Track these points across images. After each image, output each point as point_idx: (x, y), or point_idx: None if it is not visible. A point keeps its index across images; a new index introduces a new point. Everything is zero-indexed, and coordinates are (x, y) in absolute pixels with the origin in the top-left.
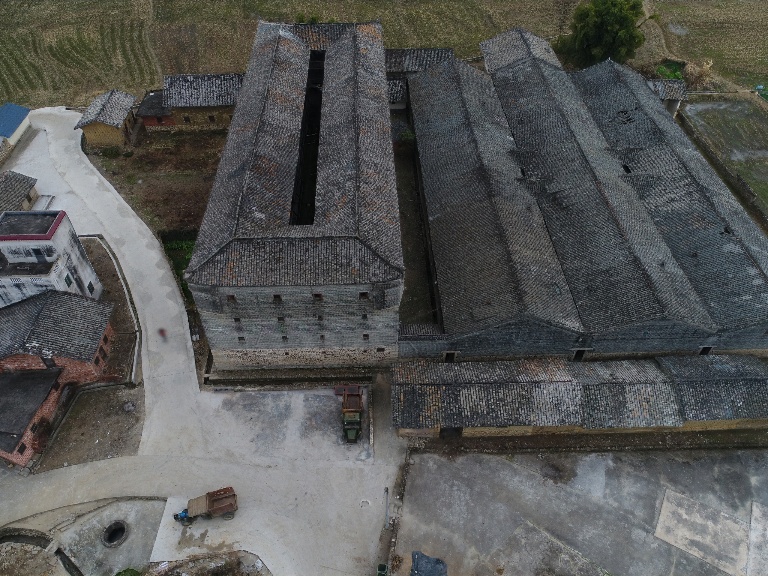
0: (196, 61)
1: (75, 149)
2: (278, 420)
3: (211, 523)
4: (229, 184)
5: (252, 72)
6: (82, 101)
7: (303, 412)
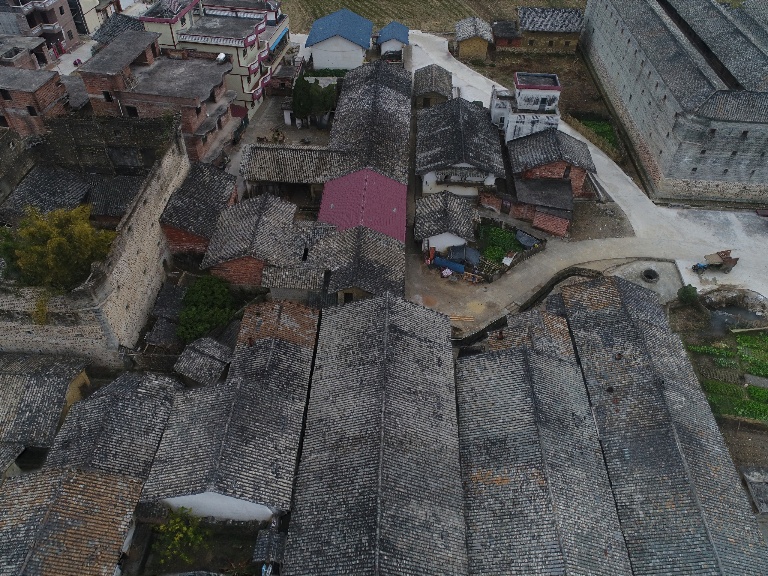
0: (496, 6)
1: (451, 59)
2: (725, 226)
3: (715, 274)
4: (674, 64)
5: (620, 1)
6: (427, 28)
7: (740, 223)
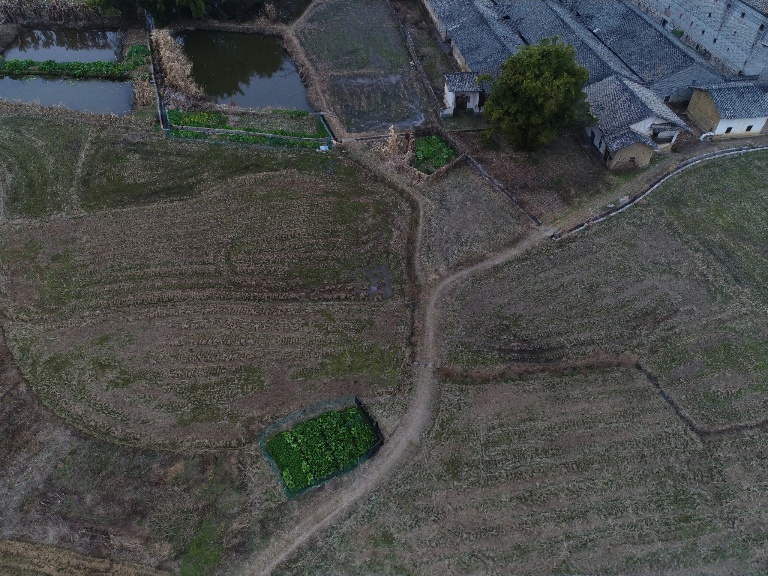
0: None
1: None
2: None
3: None
4: None
5: None
6: None
7: None
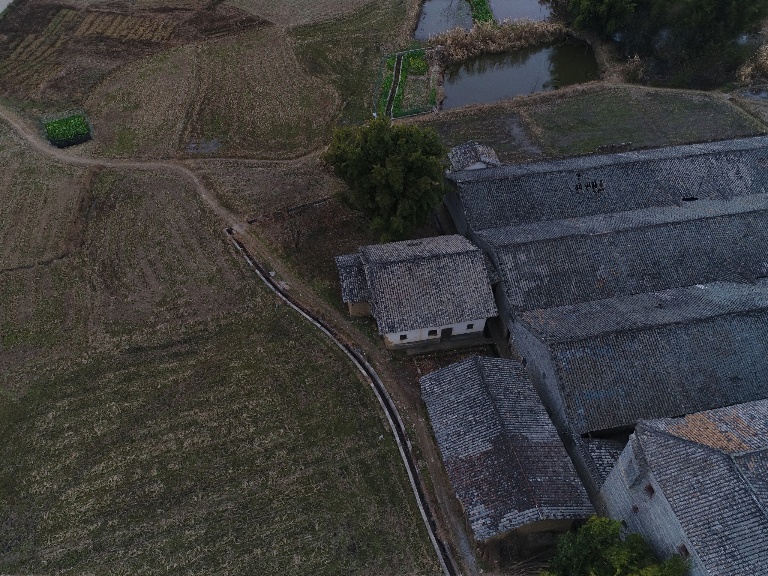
0: None
1: None
2: None
3: None
4: None
5: None
6: None
7: None
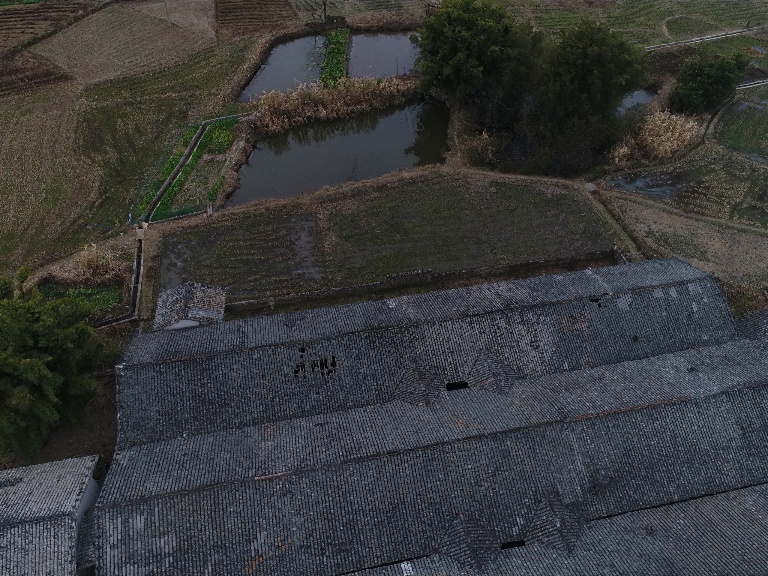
0: None
1: None
2: None
3: None
4: None
5: None
6: None
7: None
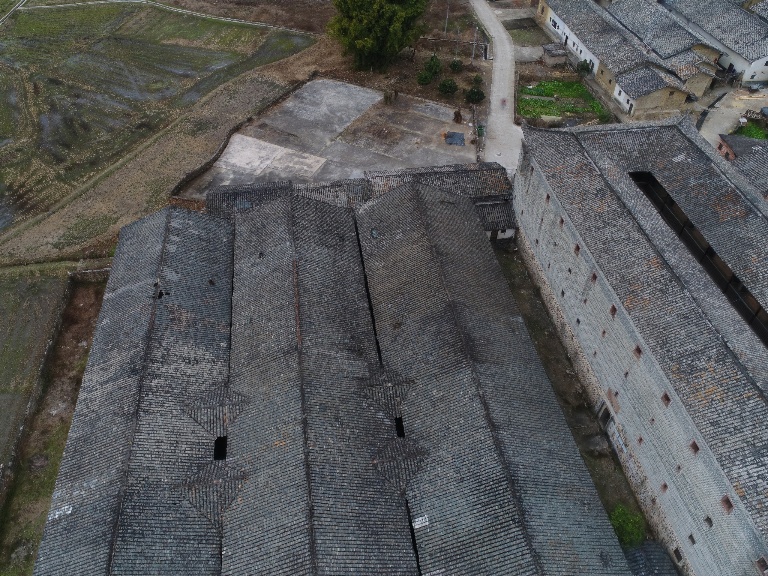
0: None
1: None
2: None
3: None
4: None
5: None
6: None
7: None
